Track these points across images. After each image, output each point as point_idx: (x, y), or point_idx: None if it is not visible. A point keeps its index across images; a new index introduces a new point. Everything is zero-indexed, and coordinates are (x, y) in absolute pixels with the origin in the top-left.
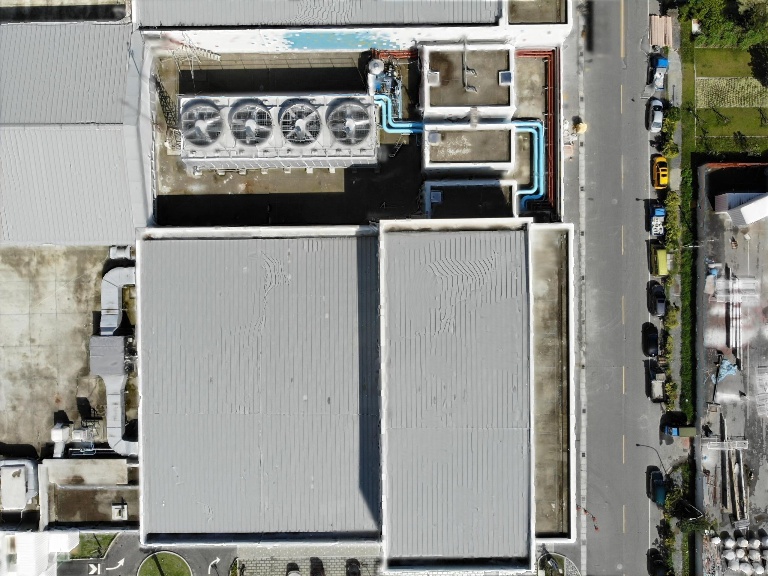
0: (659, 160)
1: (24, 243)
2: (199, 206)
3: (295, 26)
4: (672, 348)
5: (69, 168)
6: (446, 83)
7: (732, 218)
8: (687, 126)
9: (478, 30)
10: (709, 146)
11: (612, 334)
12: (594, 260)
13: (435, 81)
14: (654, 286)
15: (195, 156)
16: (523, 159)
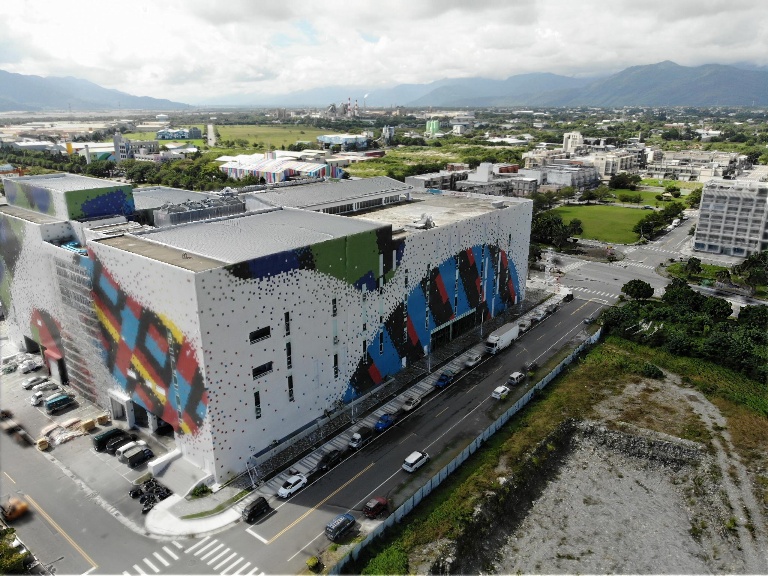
0: None
1: None
2: None
3: None
4: None
5: None
6: None
7: None
8: None
9: None
10: None
11: None
12: None
13: None
14: None
15: None
16: None
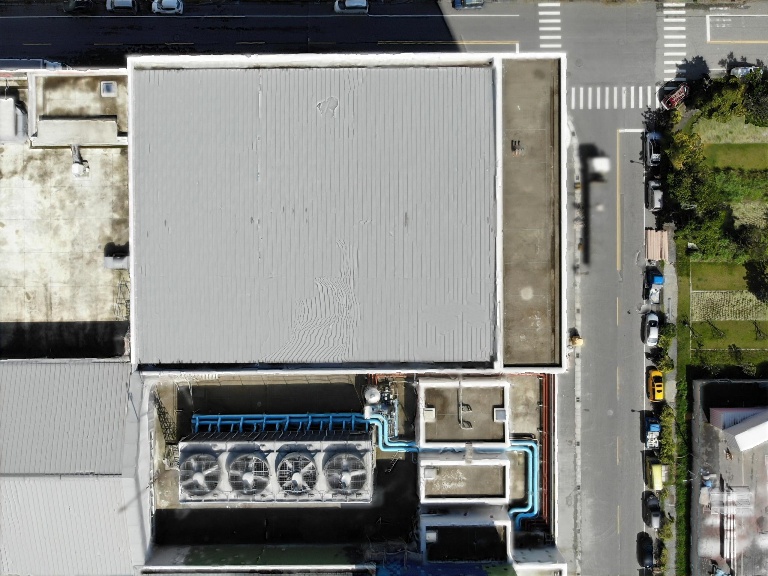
0: (654, 374)
1: (24, 575)
2: (197, 520)
3: (292, 363)
4: (667, 560)
5: (68, 511)
6: (441, 417)
7: (726, 438)
8: (682, 339)
9: (473, 372)
10: (704, 359)
11: (607, 543)
12: (590, 470)
13: (431, 418)
14: (649, 498)
15: (193, 499)
16: (518, 473)
